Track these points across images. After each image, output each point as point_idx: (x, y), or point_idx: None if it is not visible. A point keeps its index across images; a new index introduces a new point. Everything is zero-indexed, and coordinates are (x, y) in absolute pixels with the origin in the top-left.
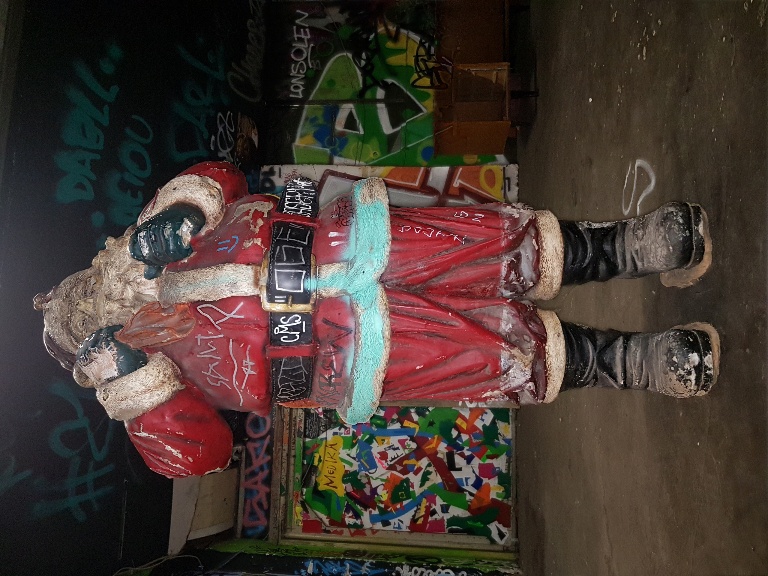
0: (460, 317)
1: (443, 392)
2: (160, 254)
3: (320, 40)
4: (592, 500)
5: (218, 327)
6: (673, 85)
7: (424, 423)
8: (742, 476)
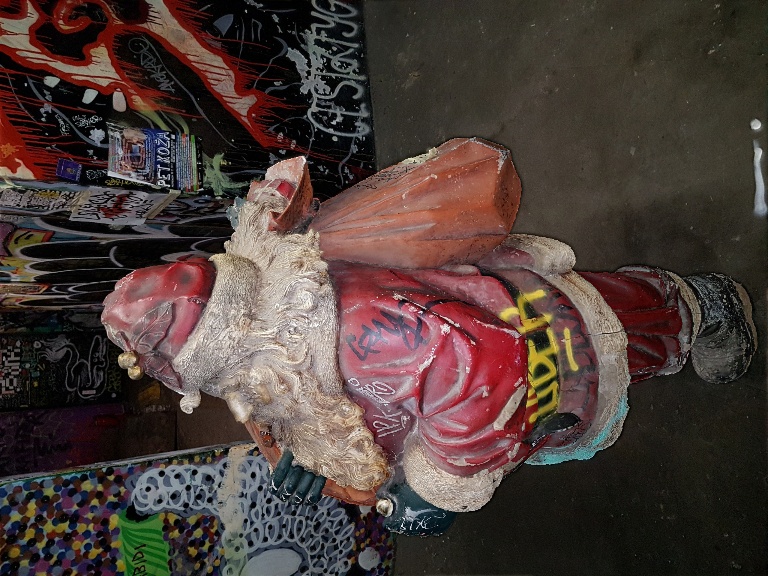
0: None
1: None
2: None
3: None
4: (497, 83)
5: None
6: None
7: None
8: None
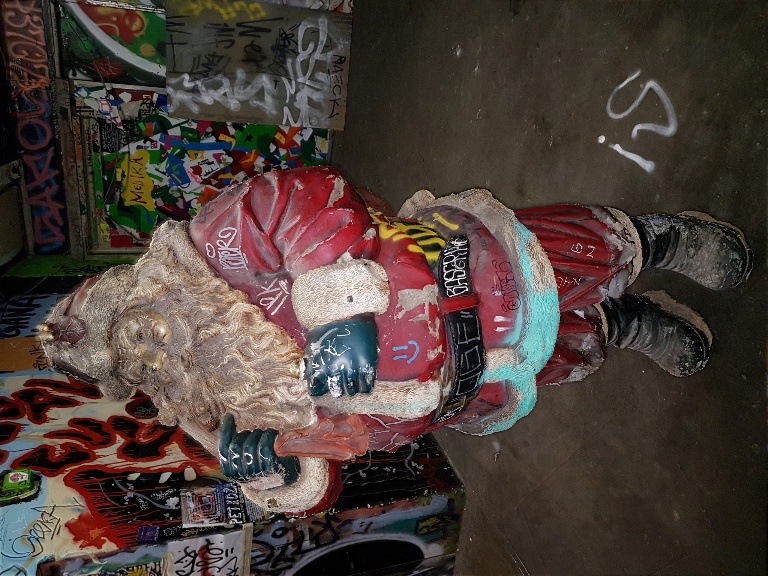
0: (564, 355)
1: None
2: None
3: None
4: None
5: (387, 427)
6: (752, 67)
7: (241, 137)
8: (690, 428)
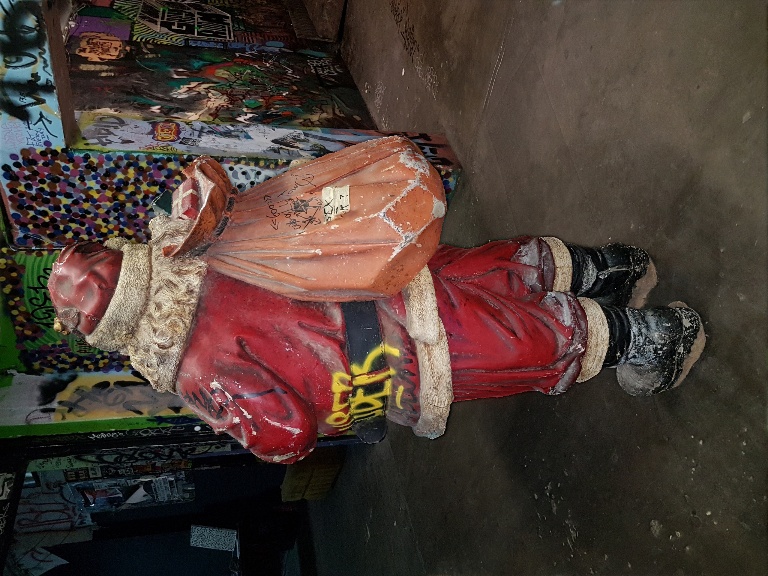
0: None
1: None
2: None
3: None
4: None
5: None
6: None
7: None
8: None
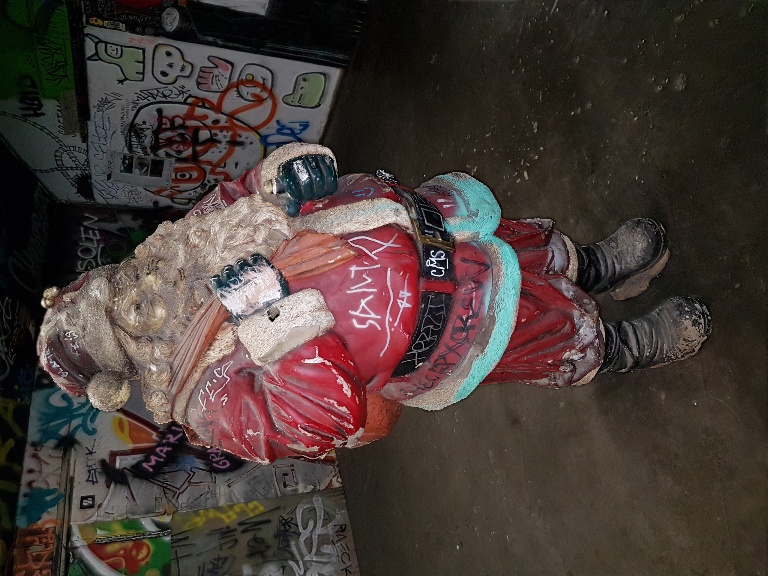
0: None
1: (533, 354)
2: (321, 180)
3: (111, 242)
4: None
5: (375, 257)
6: (572, 178)
7: None
8: (764, 383)
